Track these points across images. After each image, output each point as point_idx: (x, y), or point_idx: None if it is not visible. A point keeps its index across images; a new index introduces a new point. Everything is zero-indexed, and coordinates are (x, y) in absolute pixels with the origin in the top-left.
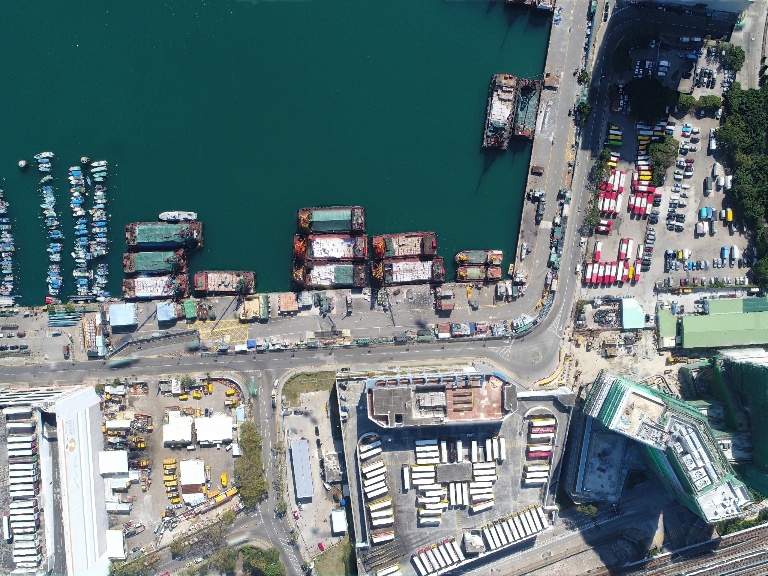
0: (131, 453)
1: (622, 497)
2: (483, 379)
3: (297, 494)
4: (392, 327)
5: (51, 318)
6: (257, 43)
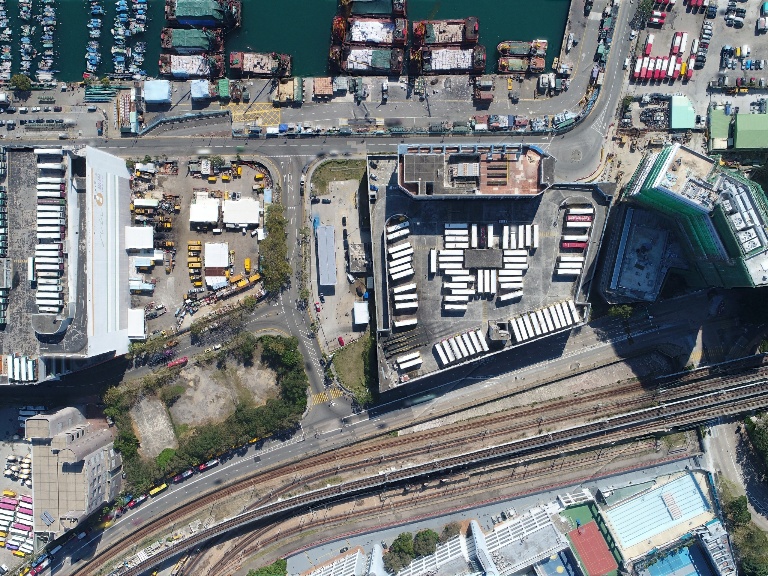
0: (157, 233)
1: (659, 309)
2: (520, 151)
3: (320, 281)
4: (427, 118)
5: (87, 93)
6: None
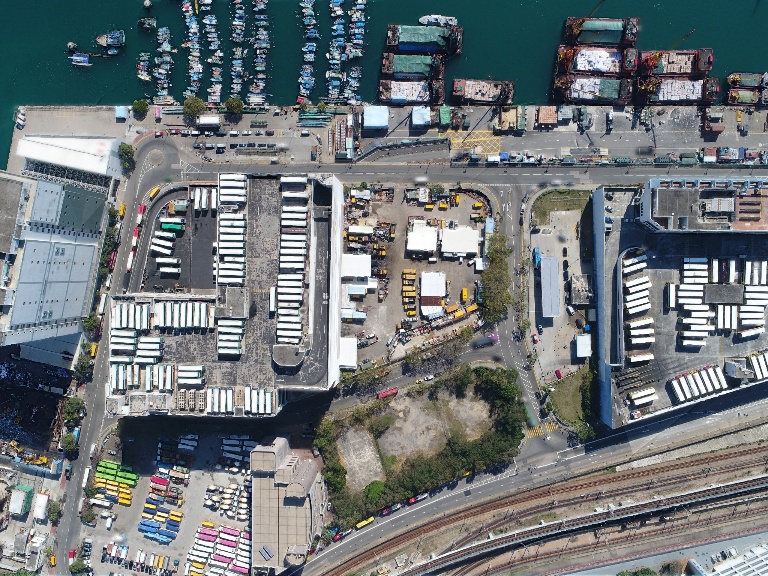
0: None
1: None
2: None
3: (543, 313)
4: (653, 148)
5: (302, 117)
6: None
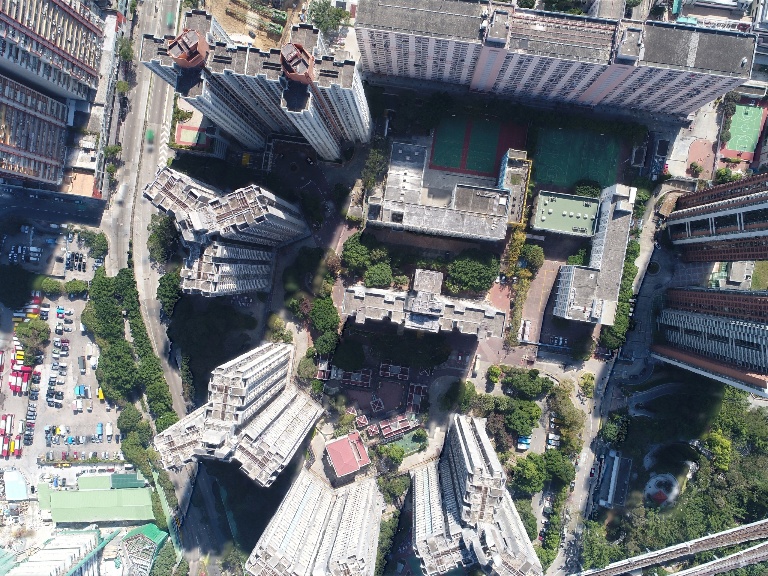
0: None
1: None
2: None
3: None
4: None
5: None
6: None
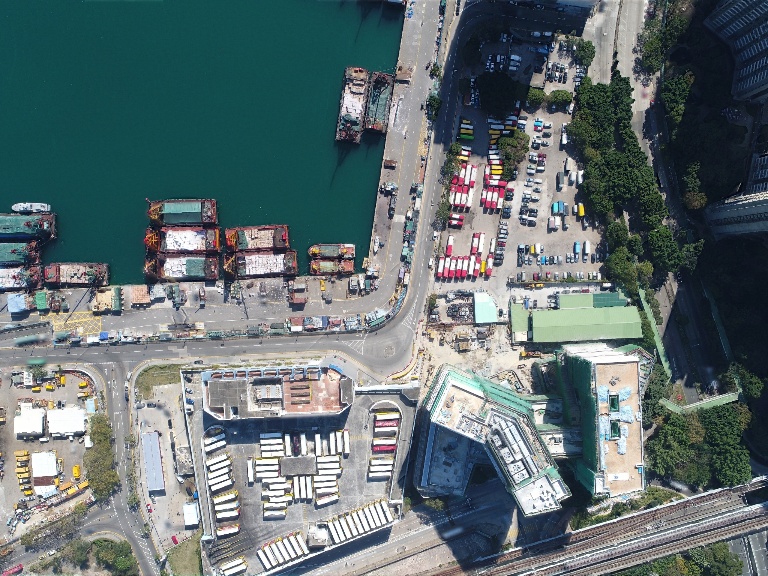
0: None
1: (476, 492)
2: (320, 372)
3: (147, 487)
4: (245, 320)
5: None
6: (110, 35)
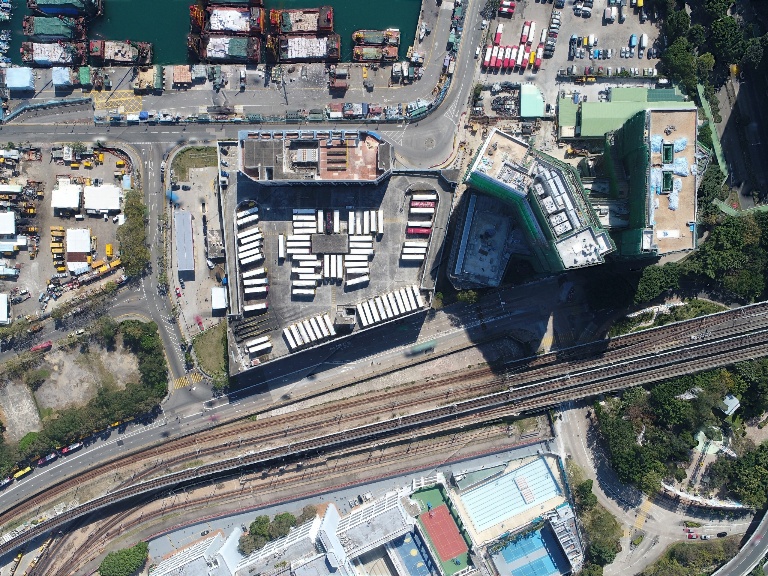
0: (21, 219)
1: (511, 295)
2: None
3: (178, 266)
4: (285, 105)
5: None
6: None
